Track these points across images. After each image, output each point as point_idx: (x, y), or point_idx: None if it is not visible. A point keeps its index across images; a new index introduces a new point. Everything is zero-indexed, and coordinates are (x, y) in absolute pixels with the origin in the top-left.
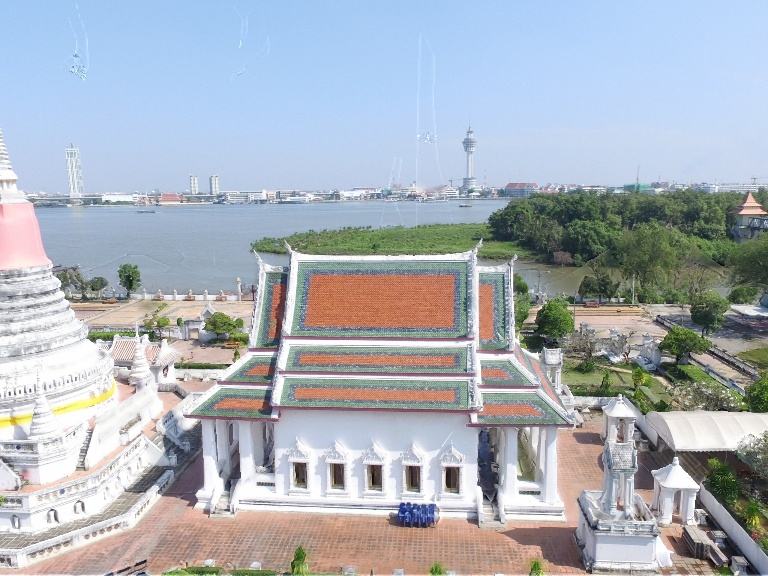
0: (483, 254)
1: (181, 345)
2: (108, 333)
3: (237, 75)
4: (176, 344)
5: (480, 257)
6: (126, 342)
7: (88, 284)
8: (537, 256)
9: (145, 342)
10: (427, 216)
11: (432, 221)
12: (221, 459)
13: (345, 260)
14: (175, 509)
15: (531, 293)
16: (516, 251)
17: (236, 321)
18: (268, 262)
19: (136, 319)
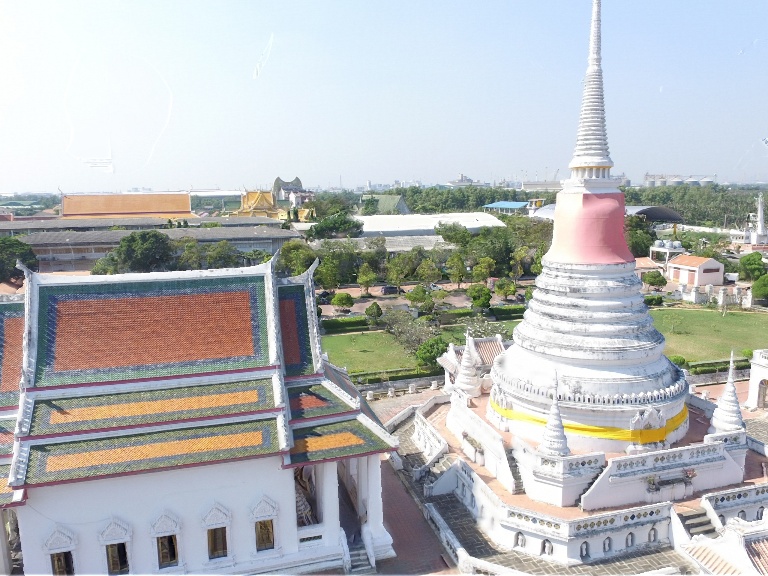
0: None
1: None
2: None
3: None
4: None
5: None
6: None
7: None
8: None
9: (765, 523)
10: None
11: None
12: None
13: (205, 274)
14: None
15: None
16: None
17: None
18: None
19: None
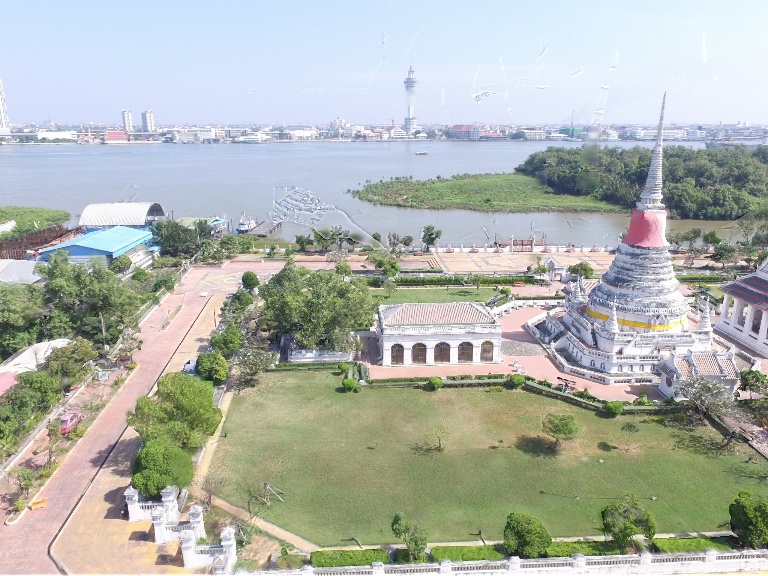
0: (584, 208)
1: (558, 284)
2: (505, 277)
3: (540, 89)
4: (553, 284)
5: (584, 211)
6: (589, 283)
7: (403, 241)
8: (628, 210)
9: None
10: (582, 182)
11: (584, 186)
12: (765, 338)
13: None
14: (761, 360)
15: (719, 244)
16: (606, 205)
17: (570, 267)
18: (433, 217)
19: (478, 267)
